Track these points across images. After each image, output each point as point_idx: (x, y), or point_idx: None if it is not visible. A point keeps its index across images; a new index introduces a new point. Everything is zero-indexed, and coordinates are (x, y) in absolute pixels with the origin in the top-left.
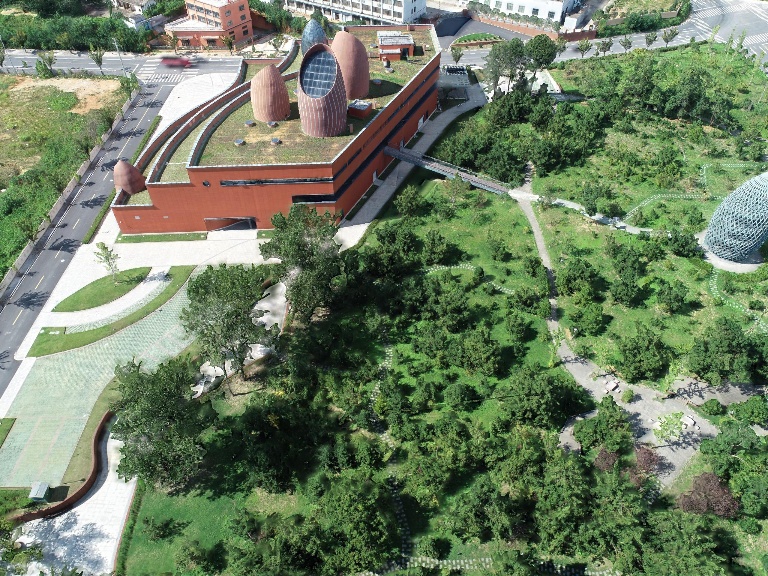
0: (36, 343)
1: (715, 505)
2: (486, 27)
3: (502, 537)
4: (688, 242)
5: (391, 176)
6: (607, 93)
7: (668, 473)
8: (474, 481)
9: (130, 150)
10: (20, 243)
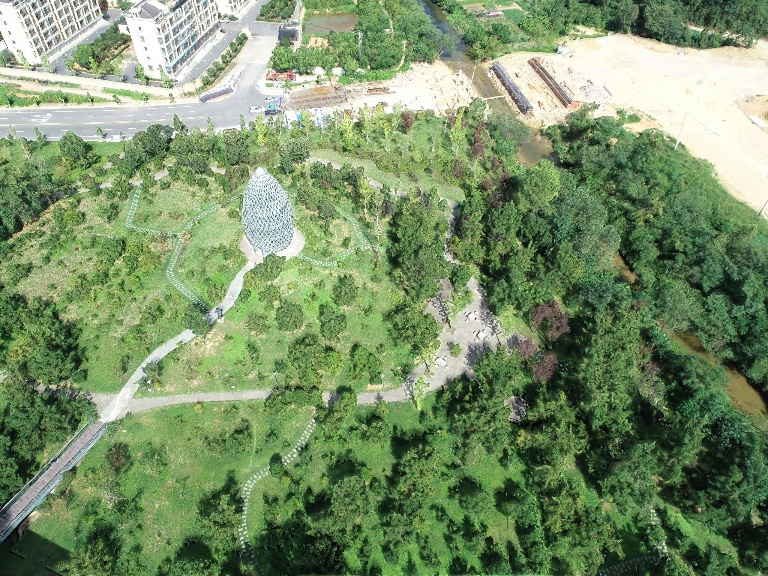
0: None
1: None
2: None
3: None
4: None
5: None
6: None
7: None
8: None
9: None
10: None
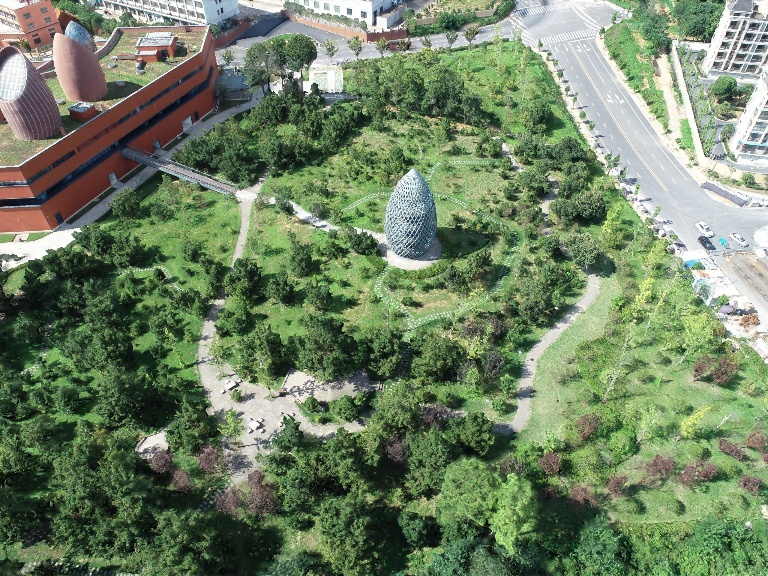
0: None
1: (249, 503)
2: (300, 27)
3: (47, 541)
4: (362, 240)
5: (134, 178)
6: (372, 92)
7: (243, 472)
8: (47, 485)
9: None
10: None
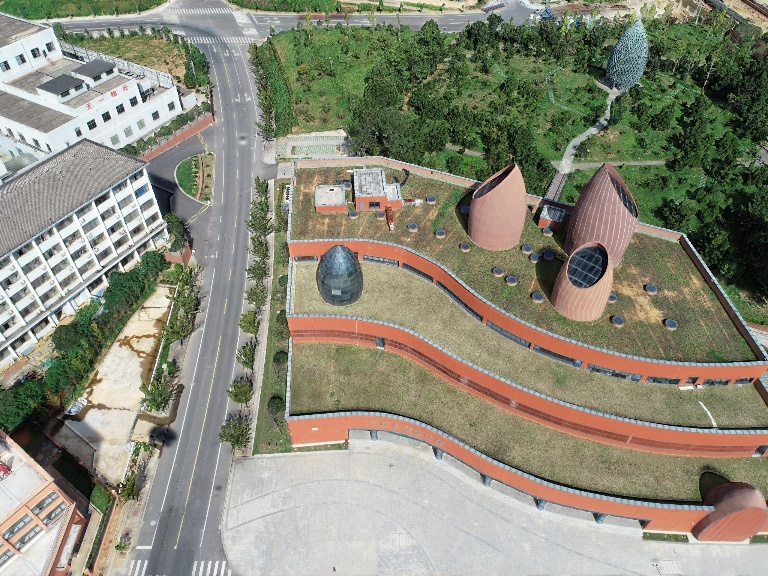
0: None
1: None
2: (158, 164)
3: None
4: None
5: None
6: None
7: None
8: None
9: None
10: None
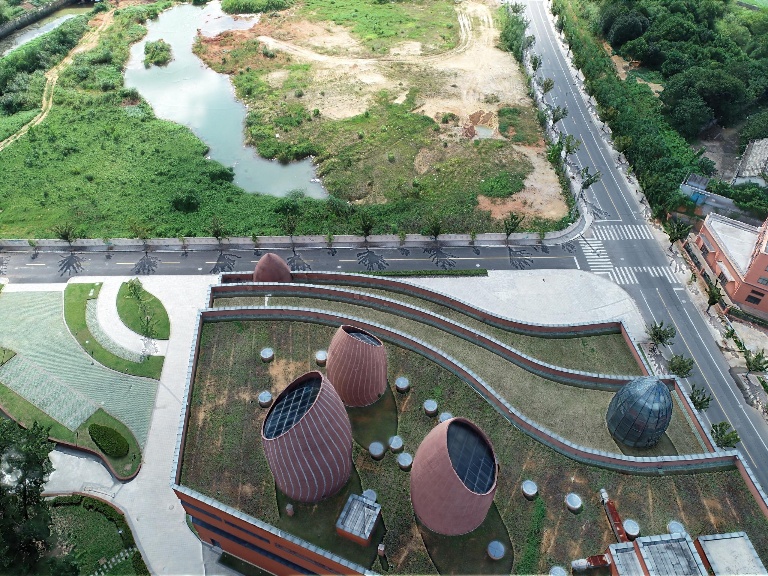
0: (83, 285)
1: None
2: None
3: None
4: None
5: None
6: None
7: None
8: None
9: (404, 266)
10: (227, 233)
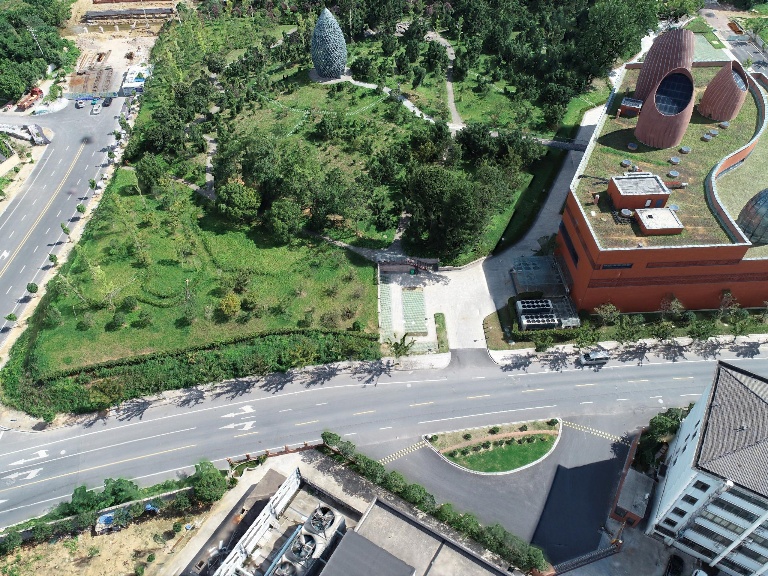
0: None
1: None
2: (485, 507)
3: None
4: None
5: None
6: None
7: None
8: None
9: None
10: None
